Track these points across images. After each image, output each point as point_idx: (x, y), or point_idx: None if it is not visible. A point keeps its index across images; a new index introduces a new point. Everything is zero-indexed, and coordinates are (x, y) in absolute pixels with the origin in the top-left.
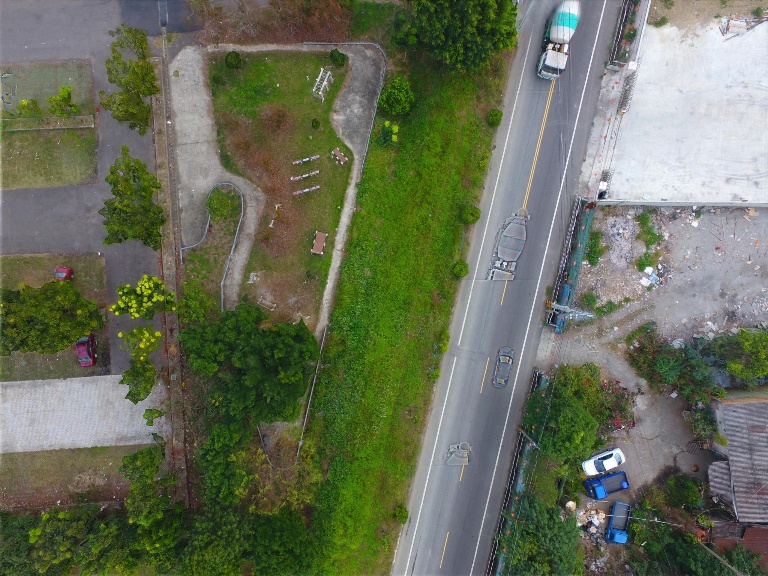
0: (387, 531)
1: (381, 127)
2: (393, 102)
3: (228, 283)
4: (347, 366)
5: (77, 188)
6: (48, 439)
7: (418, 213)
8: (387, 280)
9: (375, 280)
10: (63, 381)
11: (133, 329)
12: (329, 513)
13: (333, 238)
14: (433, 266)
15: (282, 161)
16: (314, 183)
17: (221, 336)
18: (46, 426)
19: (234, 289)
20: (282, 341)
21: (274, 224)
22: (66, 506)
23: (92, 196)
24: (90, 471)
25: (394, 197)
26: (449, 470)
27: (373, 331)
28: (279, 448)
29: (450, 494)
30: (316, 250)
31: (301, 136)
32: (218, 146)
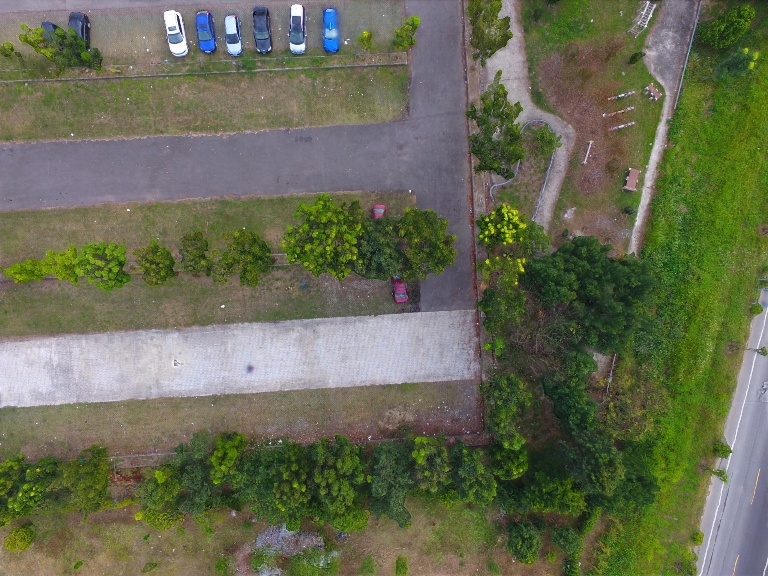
0: (707, 466)
1: (735, 55)
2: (729, 33)
3: (538, 220)
4: (664, 302)
5: (389, 125)
6: (359, 375)
7: (746, 147)
8: (711, 215)
9: (695, 216)
10: (374, 318)
11: (495, 256)
12: (649, 447)
13: (643, 175)
14: (760, 200)
15: (594, 98)
16: (626, 120)
17: (572, 265)
18: (357, 362)
19: (544, 226)
20: (632, 271)
21: (587, 161)
22: (378, 441)
23: (404, 133)
24: (400, 407)
25: (713, 132)
26: (762, 407)
27: (695, 266)
28: (588, 385)
29: (763, 431)
30: (630, 187)
31: (613, 72)
32: (529, 83)
